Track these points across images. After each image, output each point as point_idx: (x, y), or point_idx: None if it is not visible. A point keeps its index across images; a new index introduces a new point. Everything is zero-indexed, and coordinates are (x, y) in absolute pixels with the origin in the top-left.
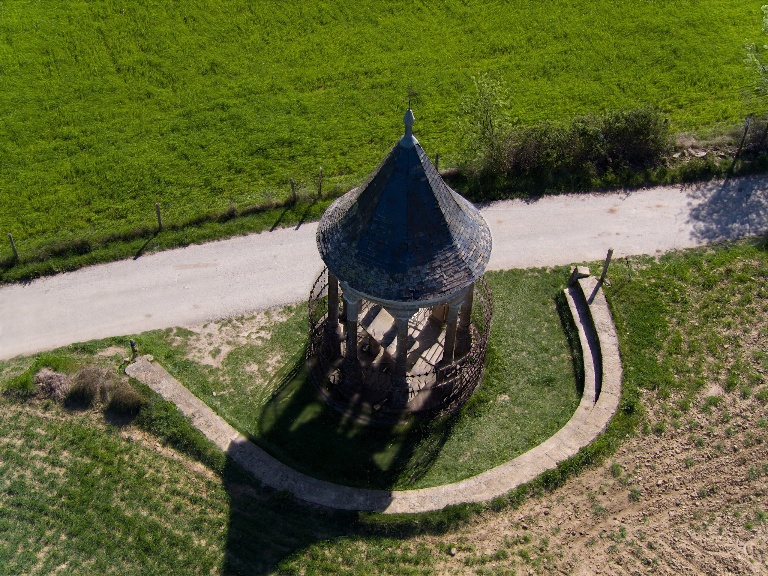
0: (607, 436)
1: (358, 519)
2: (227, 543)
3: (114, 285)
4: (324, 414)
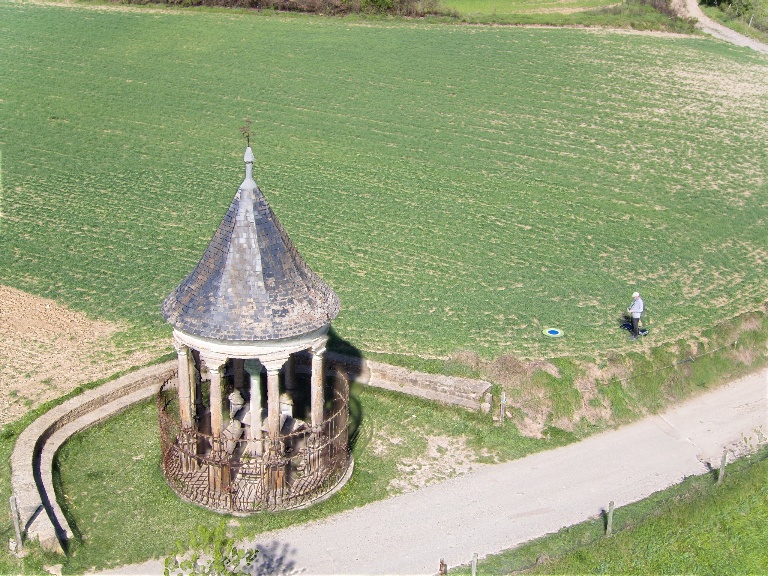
0: (35, 415)
1: None
2: None
3: (598, 486)
4: None
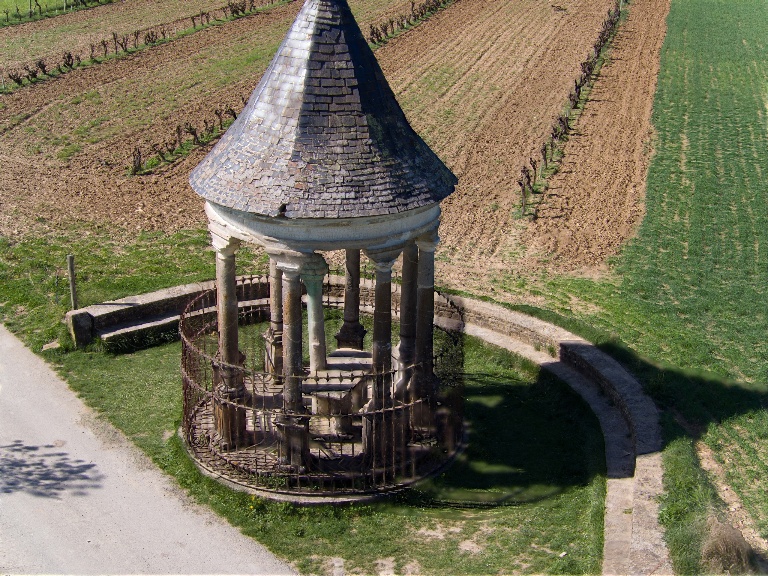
0: None
1: (618, 338)
2: (759, 407)
3: None
4: (484, 449)
